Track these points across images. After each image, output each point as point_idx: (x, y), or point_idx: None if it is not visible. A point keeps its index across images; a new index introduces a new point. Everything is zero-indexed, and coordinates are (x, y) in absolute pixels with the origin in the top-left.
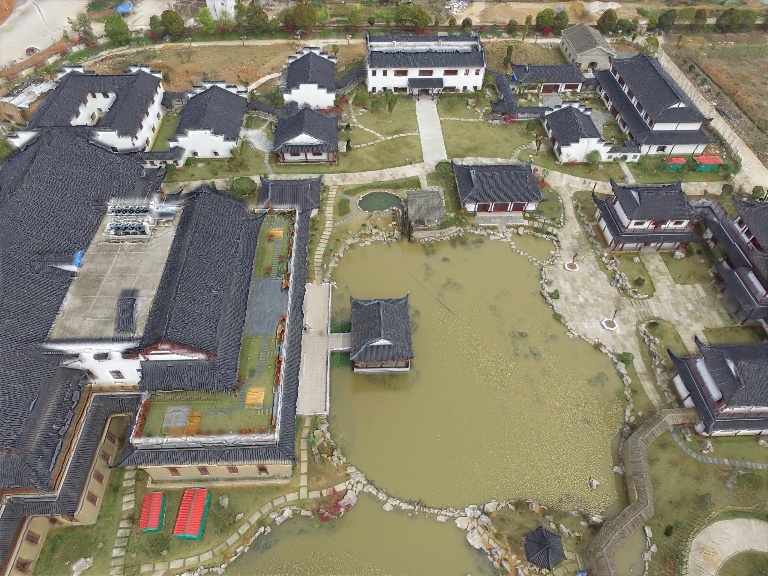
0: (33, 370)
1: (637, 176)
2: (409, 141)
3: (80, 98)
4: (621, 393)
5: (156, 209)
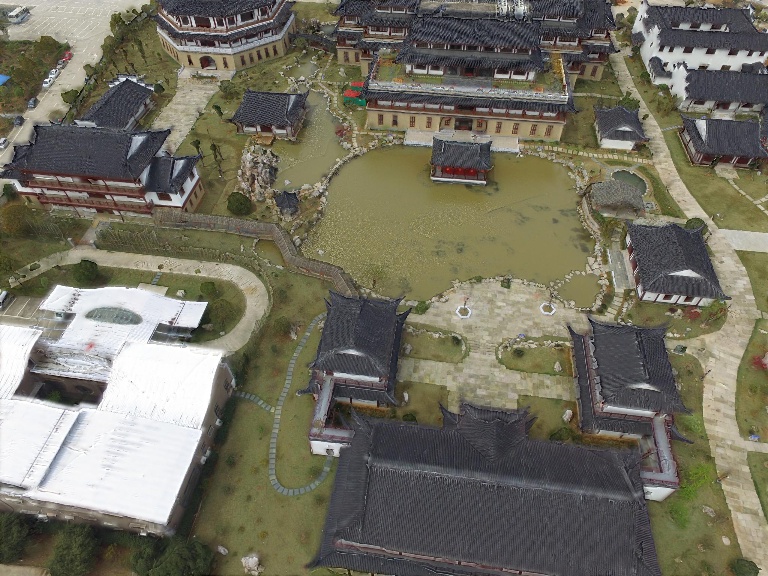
0: (411, 1)
1: (767, 459)
2: (761, 222)
3: (714, 21)
4: (388, 295)
5: (523, 11)
